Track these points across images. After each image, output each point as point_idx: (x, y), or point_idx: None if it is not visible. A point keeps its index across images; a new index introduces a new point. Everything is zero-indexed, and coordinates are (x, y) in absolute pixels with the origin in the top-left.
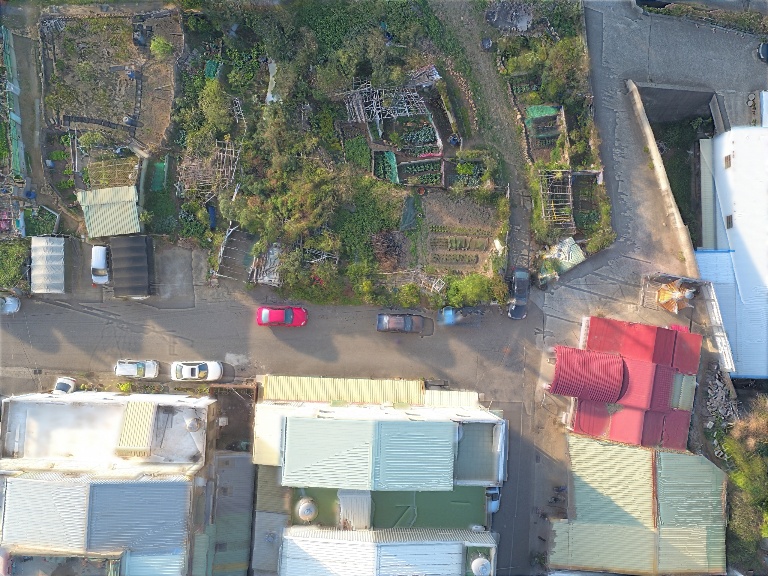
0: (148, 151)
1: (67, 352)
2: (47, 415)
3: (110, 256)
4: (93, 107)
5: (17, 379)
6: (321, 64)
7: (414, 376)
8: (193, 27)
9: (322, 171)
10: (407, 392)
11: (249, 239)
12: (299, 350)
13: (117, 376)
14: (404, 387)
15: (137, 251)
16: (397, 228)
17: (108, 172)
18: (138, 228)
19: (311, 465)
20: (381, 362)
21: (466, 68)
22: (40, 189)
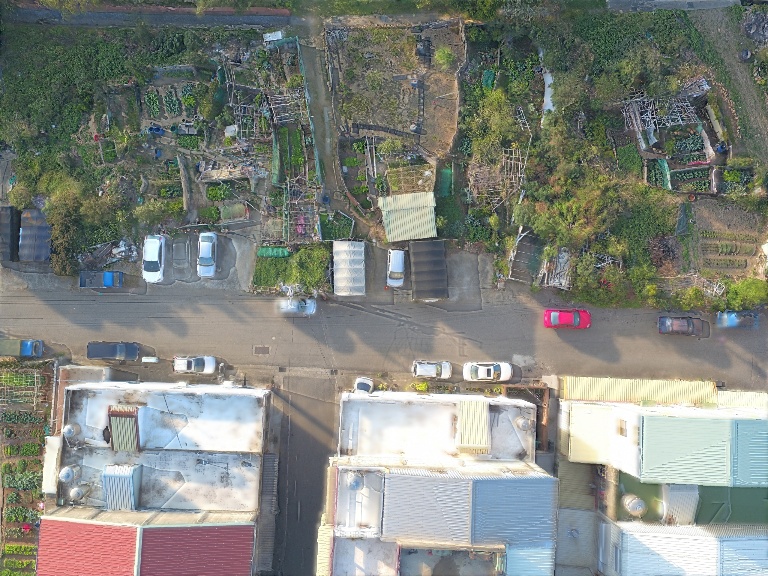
0: (436, 158)
1: (362, 353)
2: (378, 414)
3: (405, 260)
4: (379, 115)
5: (314, 379)
6: (596, 74)
7: (692, 377)
8: (474, 38)
9: (604, 178)
10: (701, 393)
11: (532, 244)
12: (583, 352)
13: (413, 376)
14: (697, 388)
15: (437, 255)
16: (671, 233)
17: (407, 178)
18: (435, 233)
19: (669, 462)
20: (661, 363)
21: (726, 78)
22: (333, 194)
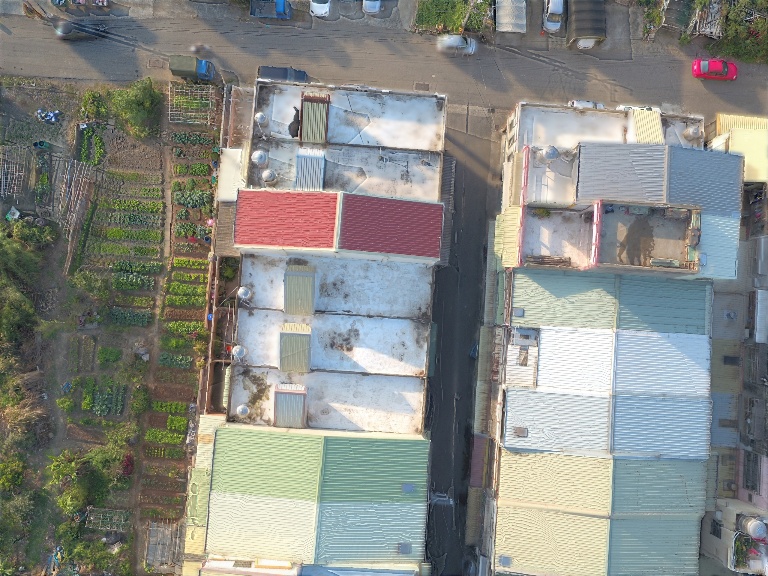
0: None
1: (518, 94)
2: (552, 122)
3: (563, 4)
4: None
5: (472, 117)
6: None
7: None
8: None
9: None
10: None
11: None
12: (728, 103)
13: None
14: None
15: None
16: None
17: None
18: None
19: None
20: None
21: None
22: None
